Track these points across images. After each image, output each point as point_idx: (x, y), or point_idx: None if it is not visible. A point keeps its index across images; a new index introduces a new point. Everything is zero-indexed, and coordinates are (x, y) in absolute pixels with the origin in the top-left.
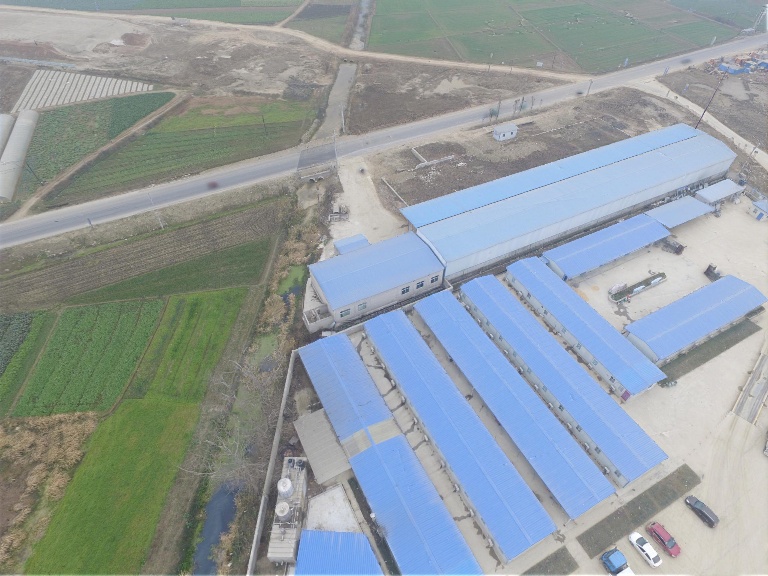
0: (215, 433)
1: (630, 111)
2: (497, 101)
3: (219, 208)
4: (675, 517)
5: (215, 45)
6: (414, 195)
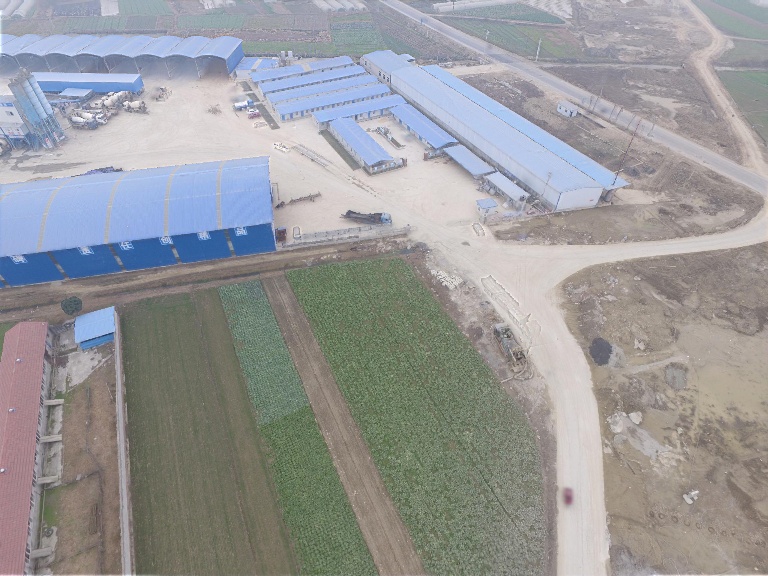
0: (319, 55)
1: (680, 186)
2: (641, 117)
3: (446, 45)
4: (261, 121)
5: (655, 23)
6: (467, 81)
